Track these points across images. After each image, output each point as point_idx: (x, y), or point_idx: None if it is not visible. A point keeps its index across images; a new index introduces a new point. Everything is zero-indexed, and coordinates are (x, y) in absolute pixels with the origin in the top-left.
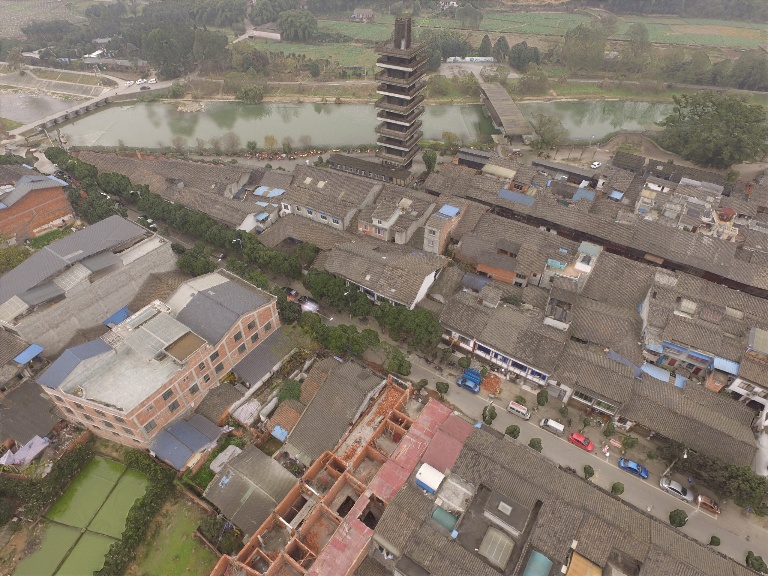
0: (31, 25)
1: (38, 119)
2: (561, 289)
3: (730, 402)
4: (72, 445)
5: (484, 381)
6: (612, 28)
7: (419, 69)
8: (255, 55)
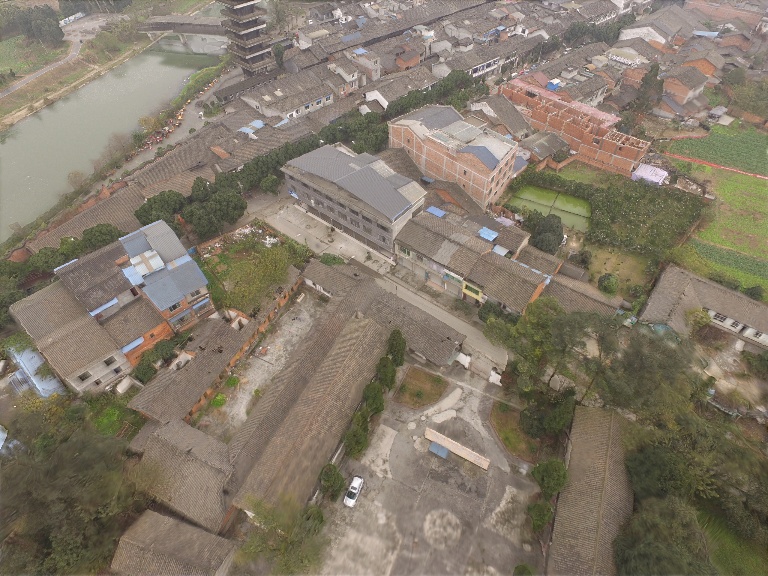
0: None
1: None
2: (450, 38)
3: None
4: (503, 207)
5: None
6: None
7: None
8: None
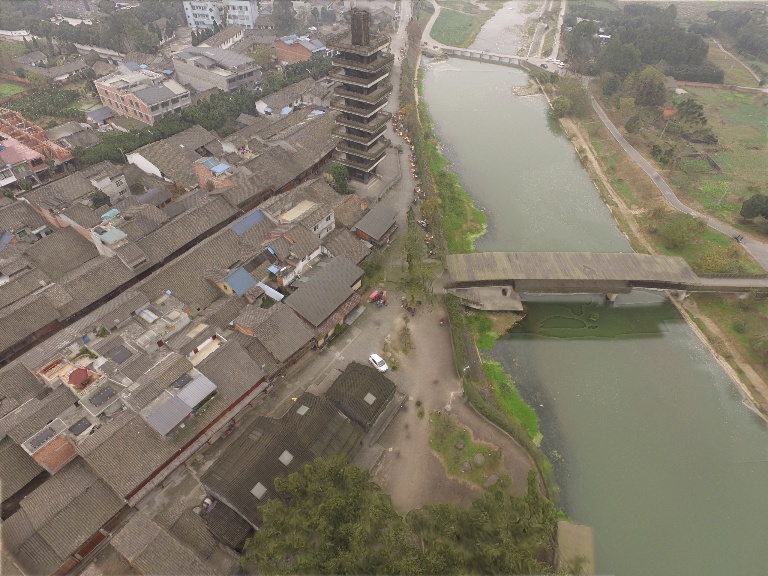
0: None
1: None
2: (74, 206)
3: None
4: None
5: None
6: None
7: None
8: (646, 87)
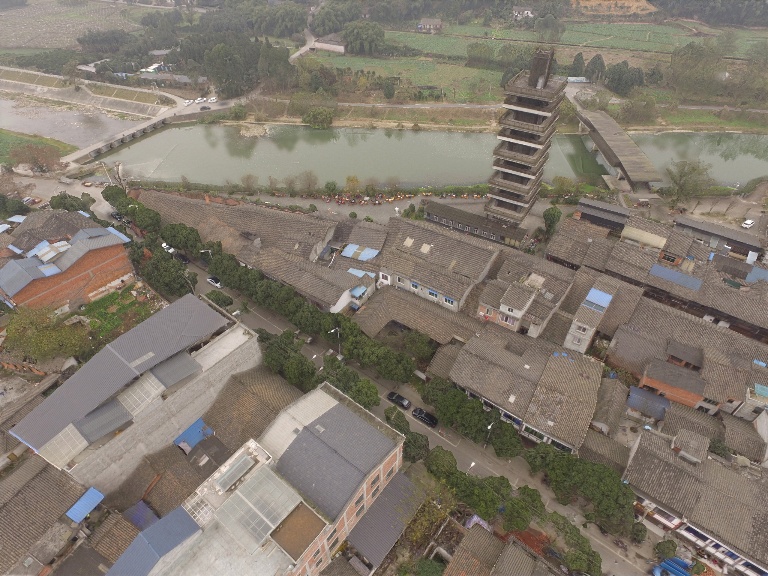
0: (87, 35)
1: (93, 142)
2: None
3: None
4: None
5: None
6: (730, 47)
7: None
8: (322, 72)
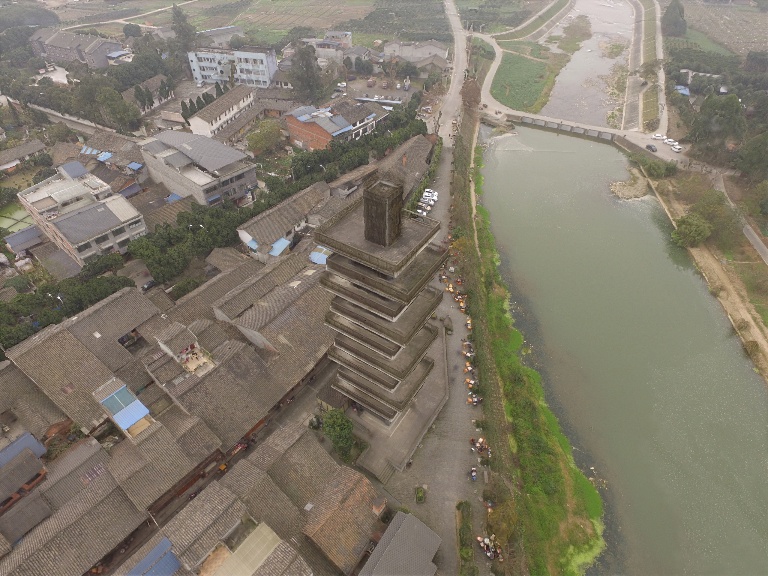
0: None
1: (551, 116)
2: None
3: None
4: None
5: None
6: None
7: (399, 303)
8: None
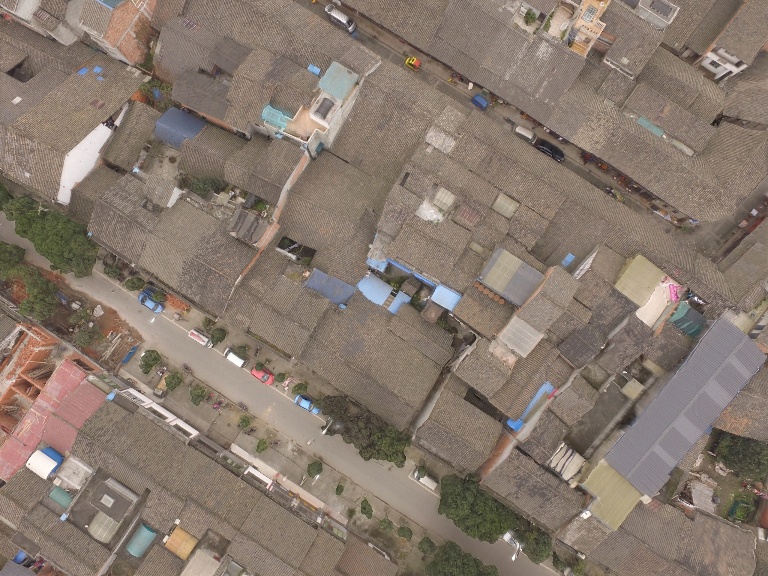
0: None
1: None
2: (261, 179)
3: (434, 340)
4: None
5: (169, 298)
6: None
7: None
8: None
